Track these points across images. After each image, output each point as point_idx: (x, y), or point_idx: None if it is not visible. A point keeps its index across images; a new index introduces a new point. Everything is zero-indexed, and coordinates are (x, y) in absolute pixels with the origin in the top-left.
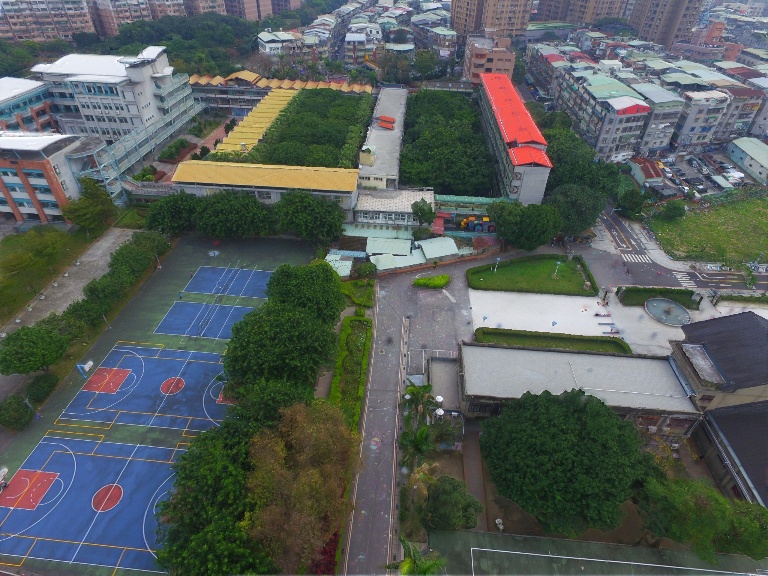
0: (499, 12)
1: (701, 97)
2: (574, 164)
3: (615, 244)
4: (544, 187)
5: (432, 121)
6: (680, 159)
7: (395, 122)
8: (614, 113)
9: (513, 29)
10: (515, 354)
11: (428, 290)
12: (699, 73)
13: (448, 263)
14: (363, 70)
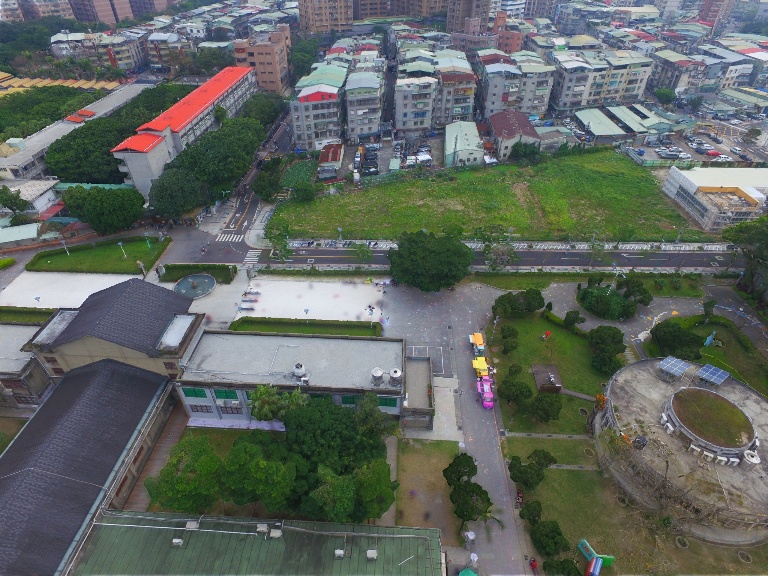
0: (317, 8)
1: (403, 83)
2: (187, 149)
3: (225, 225)
4: (151, 172)
5: (133, 114)
6: (388, 144)
7: (95, 116)
8: (296, 101)
9: (338, 24)
10: None
11: None
12: (442, 61)
13: (31, 247)
14: (110, 67)
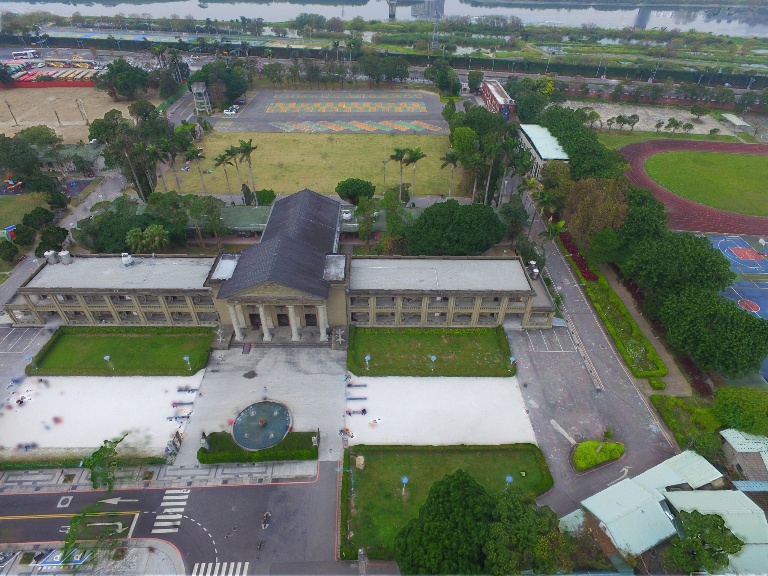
0: None
1: None
2: None
3: None
4: None
5: None
6: None
7: None
8: None
9: None
10: None
11: (596, 440)
12: None
13: None
14: None
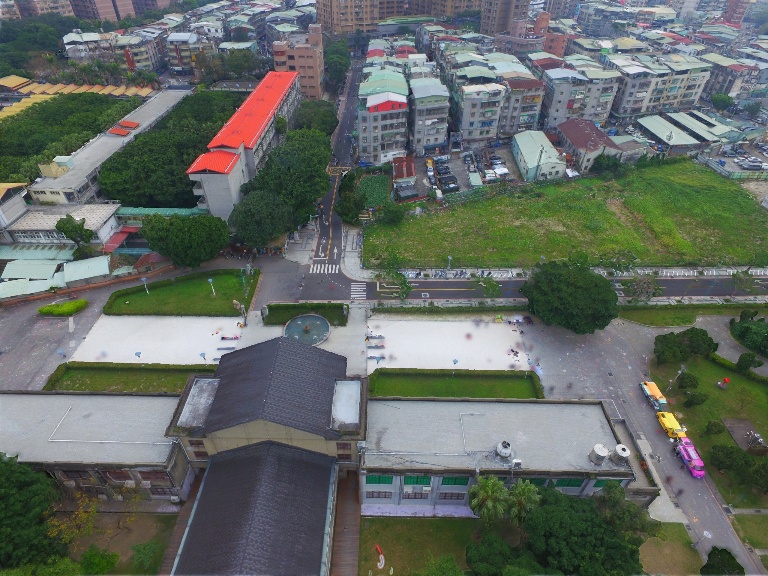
0: (343, 7)
1: (472, 91)
2: (268, 169)
3: (313, 253)
4: (230, 195)
5: (181, 125)
6: (456, 156)
7: (138, 127)
8: (365, 110)
9: (363, 24)
10: (13, 400)
11: (52, 319)
12: (498, 65)
13: (102, 285)
14: (141, 71)
